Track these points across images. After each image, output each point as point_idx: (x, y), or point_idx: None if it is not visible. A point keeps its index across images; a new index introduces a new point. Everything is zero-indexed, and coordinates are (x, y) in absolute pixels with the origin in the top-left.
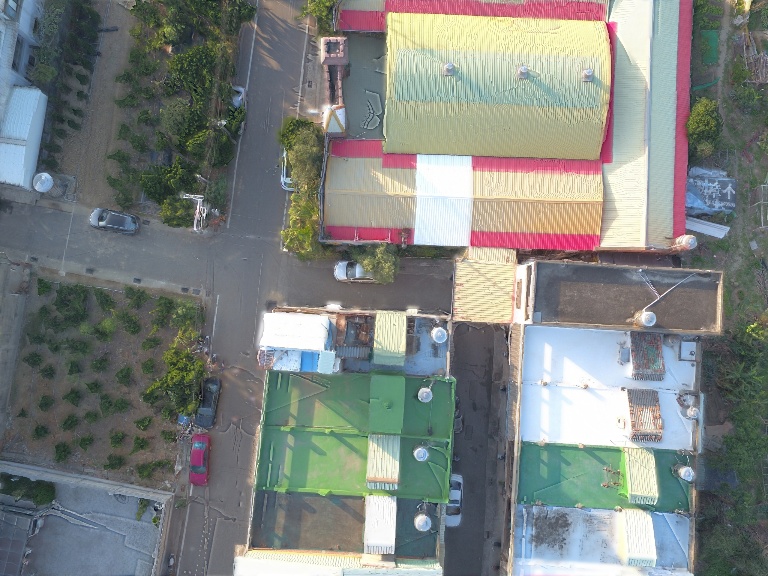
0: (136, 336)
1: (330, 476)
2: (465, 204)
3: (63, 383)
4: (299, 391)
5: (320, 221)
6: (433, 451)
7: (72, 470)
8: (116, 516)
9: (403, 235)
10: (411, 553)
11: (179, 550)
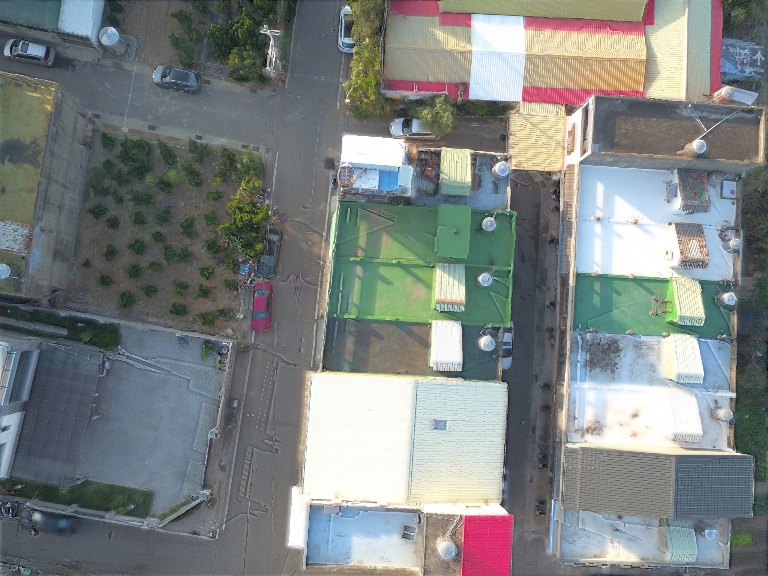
0: (198, 190)
1: (397, 304)
2: (517, 60)
3: (127, 235)
4: (367, 225)
5: (381, 72)
6: (494, 281)
7: (136, 319)
8: (181, 361)
9: (459, 88)
10: (474, 376)
11: (242, 394)
